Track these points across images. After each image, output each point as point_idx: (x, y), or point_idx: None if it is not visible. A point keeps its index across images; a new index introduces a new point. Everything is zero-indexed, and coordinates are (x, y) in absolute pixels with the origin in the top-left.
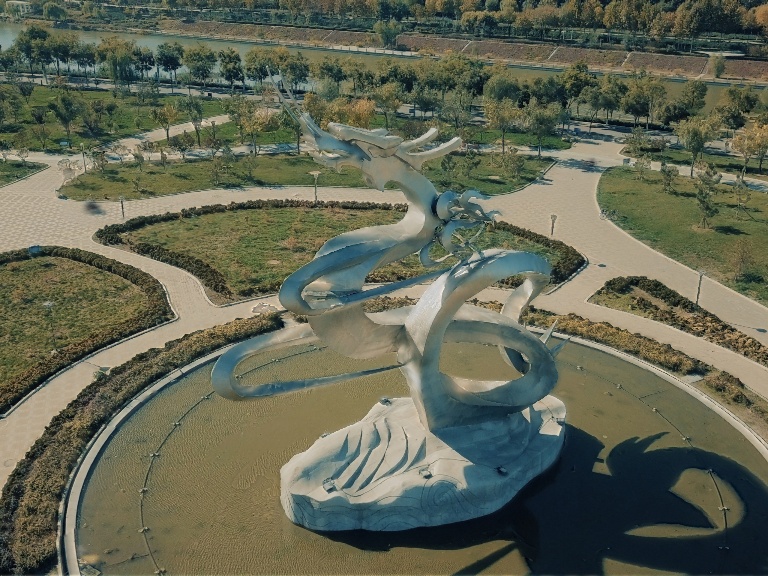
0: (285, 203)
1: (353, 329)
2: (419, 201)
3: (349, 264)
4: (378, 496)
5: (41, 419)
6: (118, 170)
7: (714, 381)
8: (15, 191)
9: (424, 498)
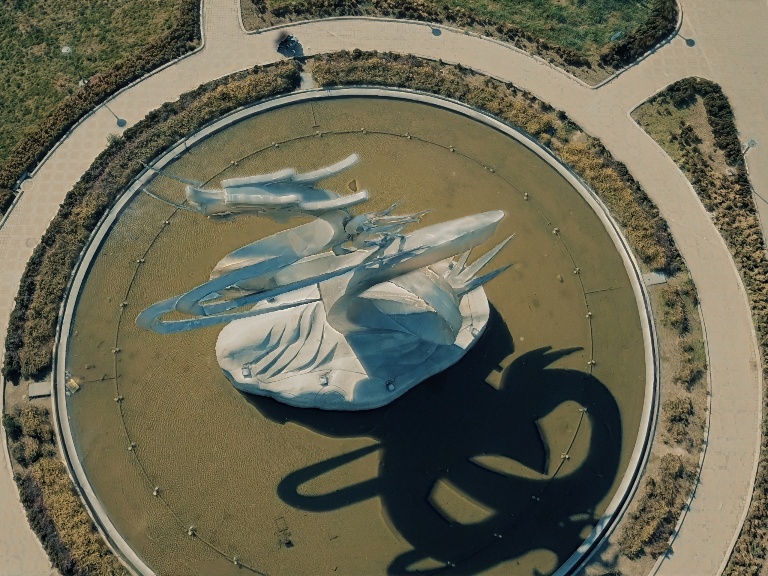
0: None
1: None
2: None
3: None
4: (282, 389)
5: (60, 188)
6: None
7: (668, 295)
8: None
9: (317, 399)
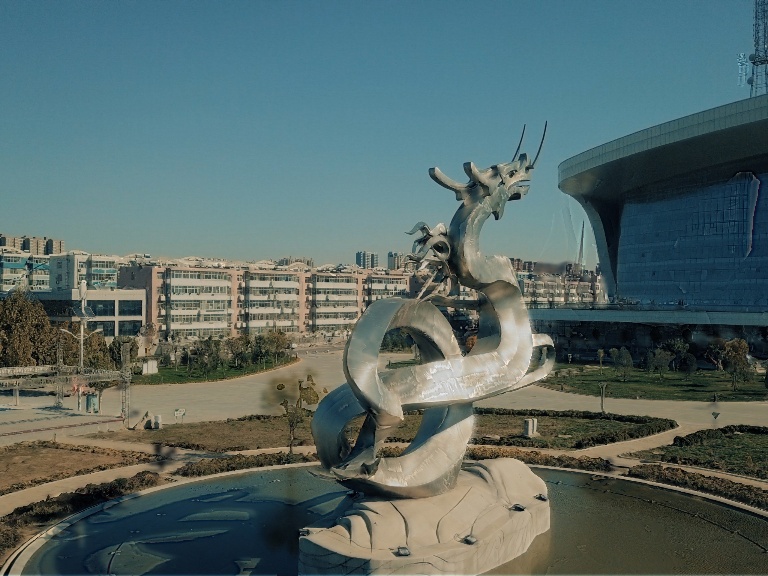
0: None
1: None
2: None
3: None
4: None
5: None
6: None
7: None
8: None
9: None
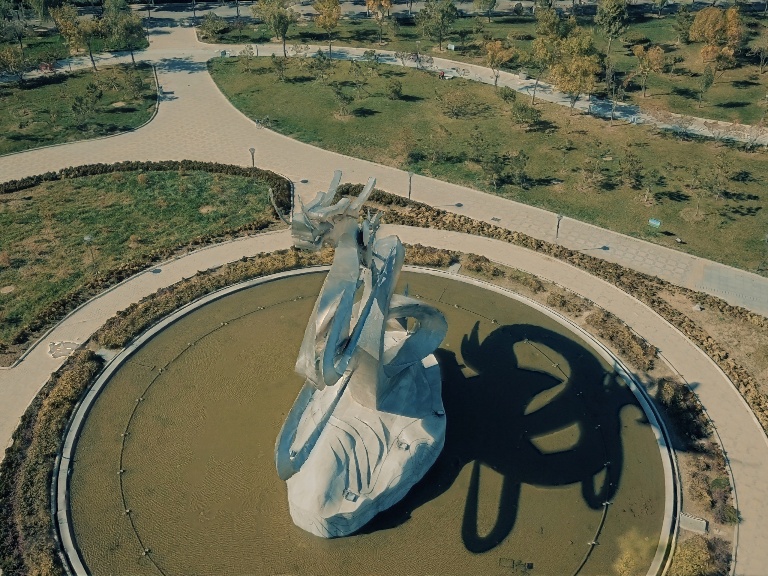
0: None
1: None
2: (351, 240)
3: None
4: (387, 483)
5: None
6: None
7: (473, 265)
8: None
9: (414, 465)
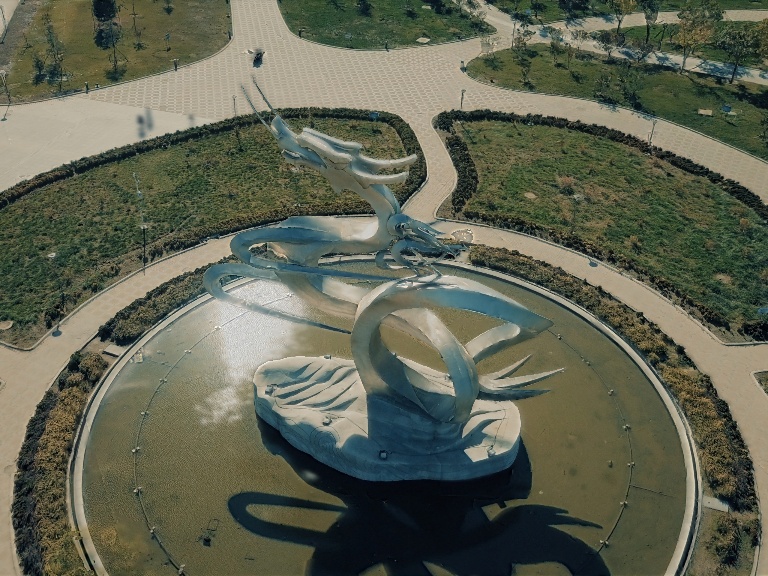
0: (623, 138)
1: (307, 289)
2: None
3: (294, 241)
4: (288, 415)
5: None
6: (539, 53)
7: (723, 519)
8: (441, 52)
9: (313, 436)
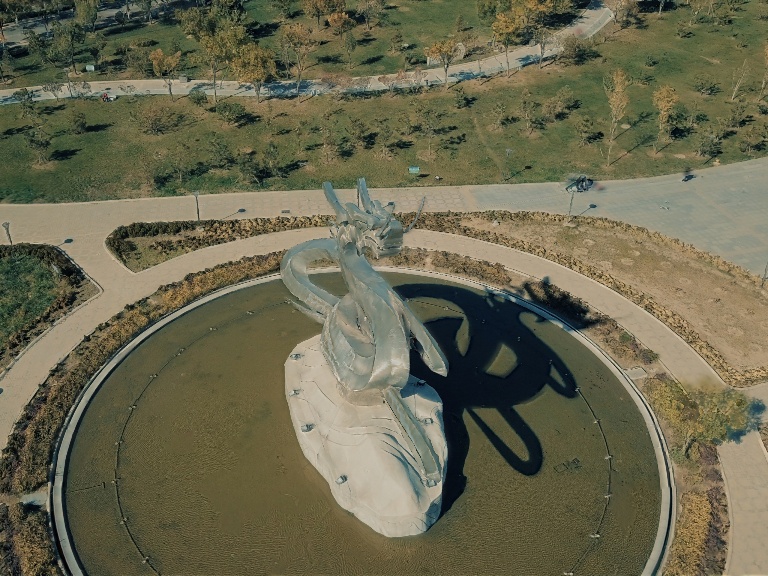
0: None
1: None
2: None
3: None
4: (441, 457)
5: None
6: None
7: None
8: None
9: None
